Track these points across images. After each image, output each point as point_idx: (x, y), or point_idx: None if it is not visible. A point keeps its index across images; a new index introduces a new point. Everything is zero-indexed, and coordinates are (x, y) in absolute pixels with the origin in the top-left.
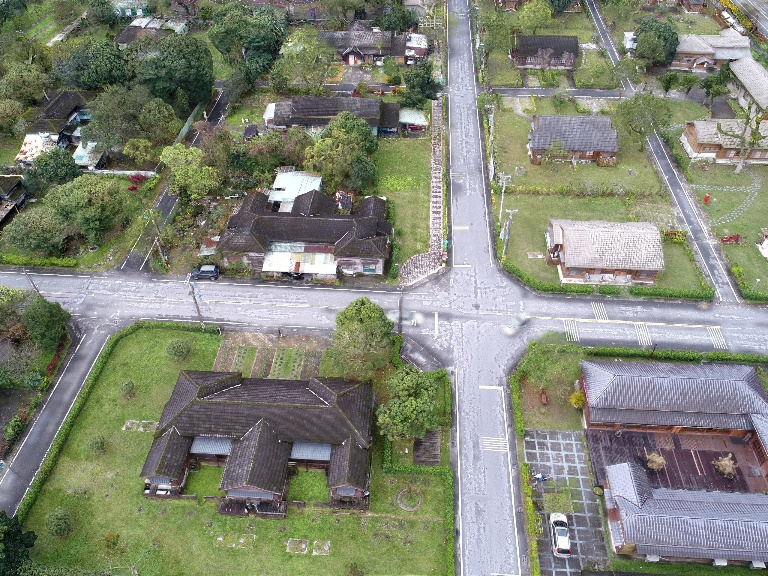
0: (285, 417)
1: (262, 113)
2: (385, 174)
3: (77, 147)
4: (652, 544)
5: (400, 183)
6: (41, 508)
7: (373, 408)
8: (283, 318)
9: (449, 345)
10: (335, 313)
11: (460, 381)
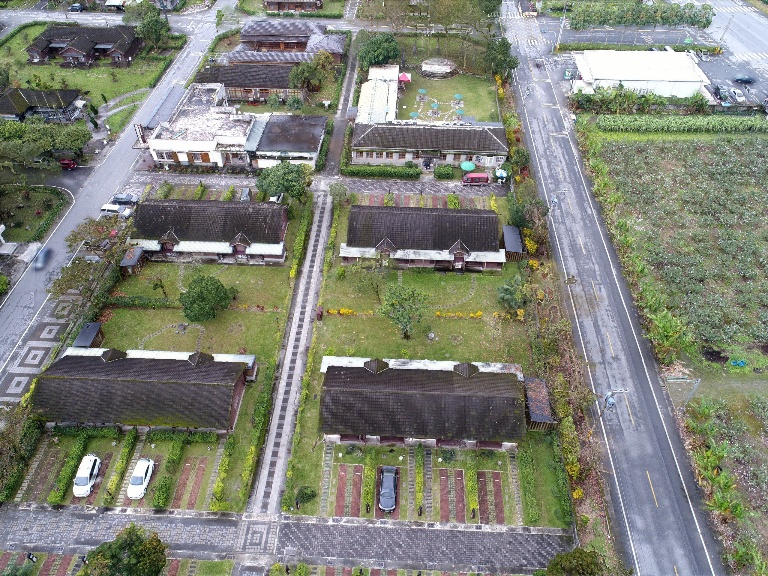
0: (93, 32)
1: None
2: None
3: None
4: None
5: None
6: None
7: (145, 45)
8: (112, 22)
9: (193, 30)
10: None
11: (192, 39)
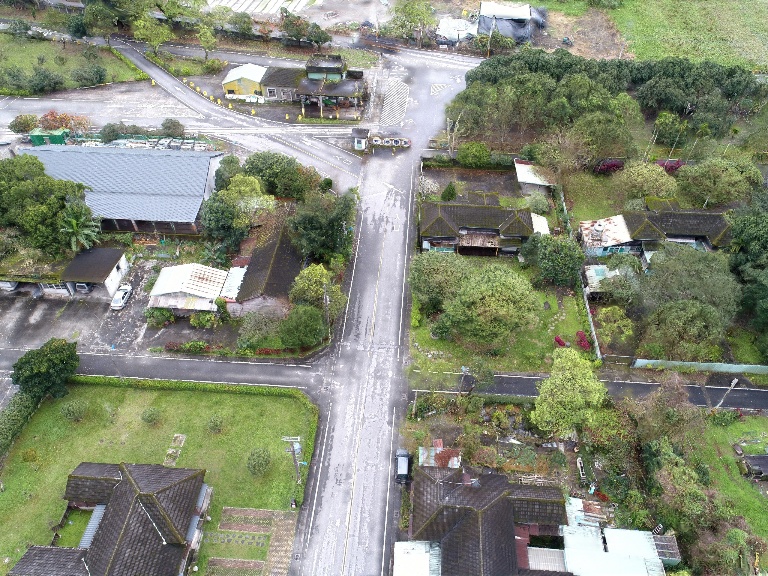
0: None
1: None
2: None
3: None
4: None
5: None
6: (109, 393)
7: None
8: None
9: None
10: None
11: None
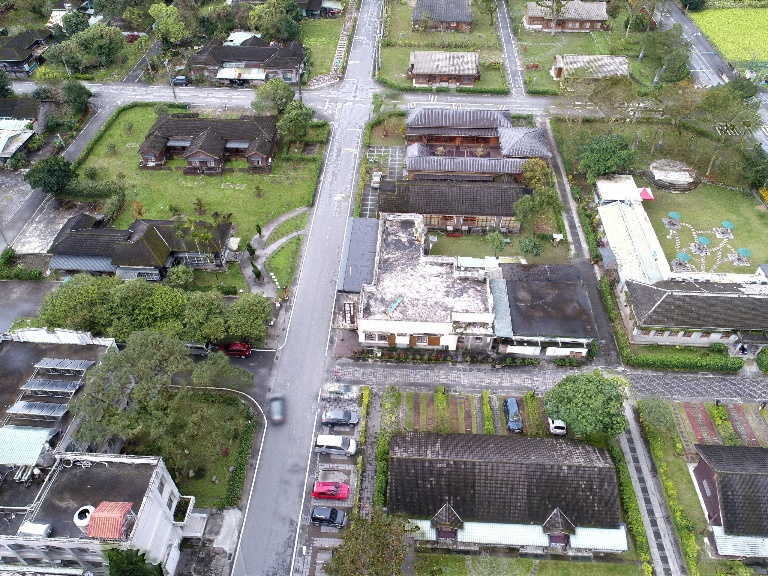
0: (223, 126)
1: None
2: (308, 37)
3: (89, 19)
4: (422, 172)
5: (317, 41)
6: None
7: (280, 138)
8: (229, 102)
9: (333, 113)
10: None
11: (336, 127)
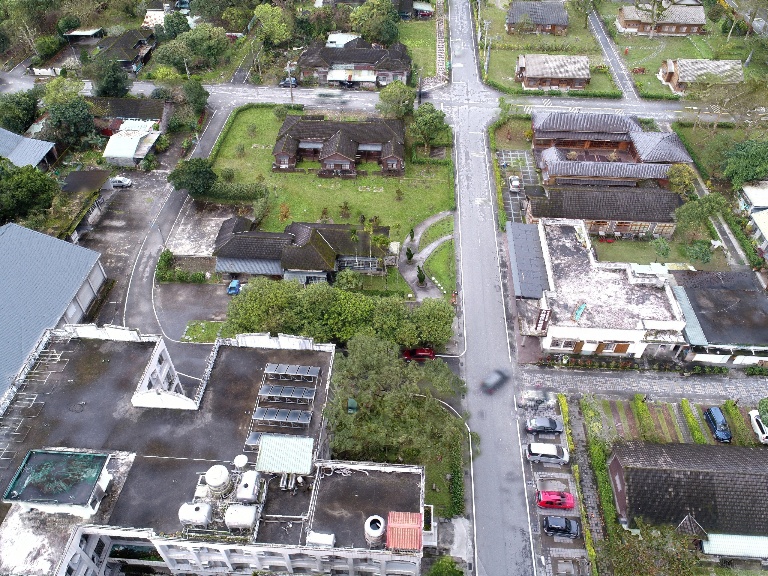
0: (354, 129)
1: (311, 6)
2: (404, 39)
3: None
4: (564, 177)
5: (415, 43)
6: None
7: None
8: (343, 104)
9: (450, 116)
10: (376, 102)
11: (457, 130)
